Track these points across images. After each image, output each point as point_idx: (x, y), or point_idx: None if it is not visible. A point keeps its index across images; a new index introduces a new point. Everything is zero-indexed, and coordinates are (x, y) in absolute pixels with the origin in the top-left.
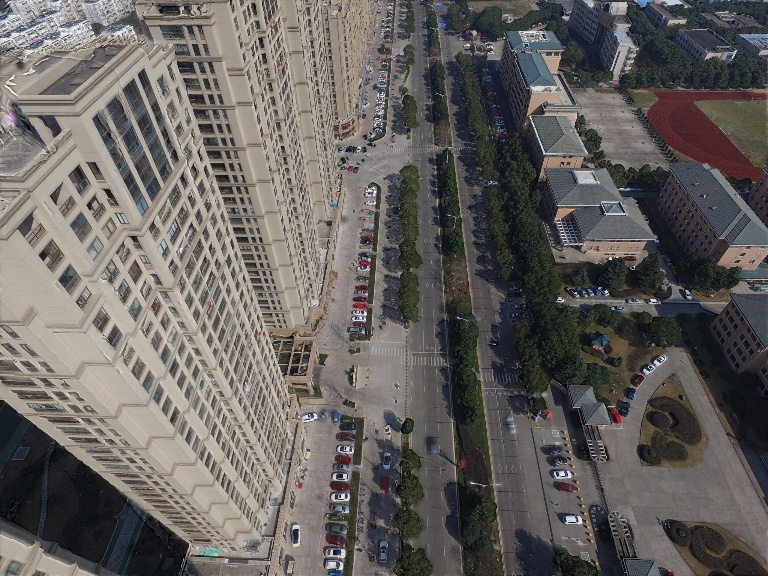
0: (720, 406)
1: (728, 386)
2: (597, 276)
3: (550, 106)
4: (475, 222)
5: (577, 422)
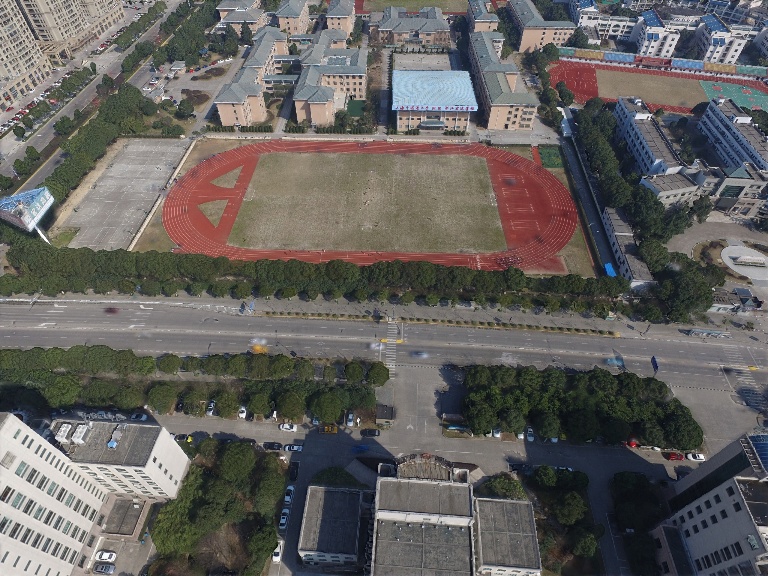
0: None
1: None
2: None
3: None
4: None
5: None
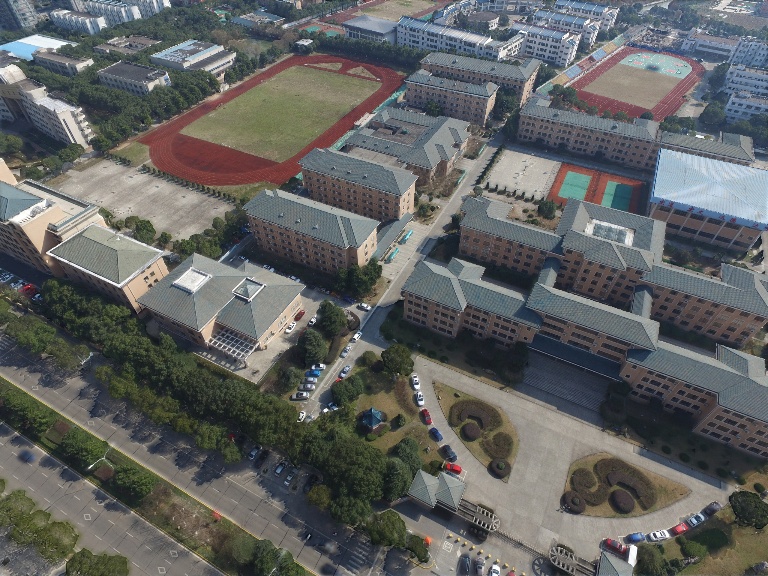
0: (476, 373)
1: (461, 353)
2: (301, 360)
3: (60, 226)
4: (122, 425)
5: (447, 514)
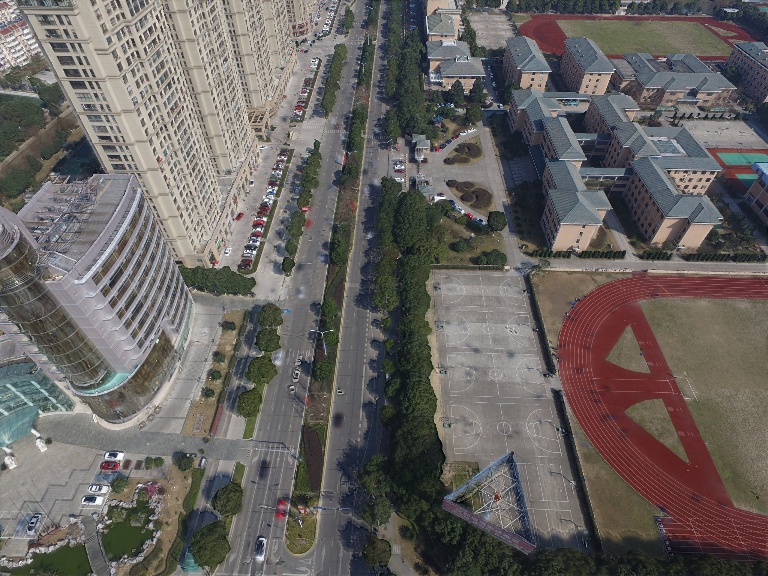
0: (497, 146)
1: (506, 139)
2: None
3: (440, 9)
4: (381, 76)
5: (414, 150)
